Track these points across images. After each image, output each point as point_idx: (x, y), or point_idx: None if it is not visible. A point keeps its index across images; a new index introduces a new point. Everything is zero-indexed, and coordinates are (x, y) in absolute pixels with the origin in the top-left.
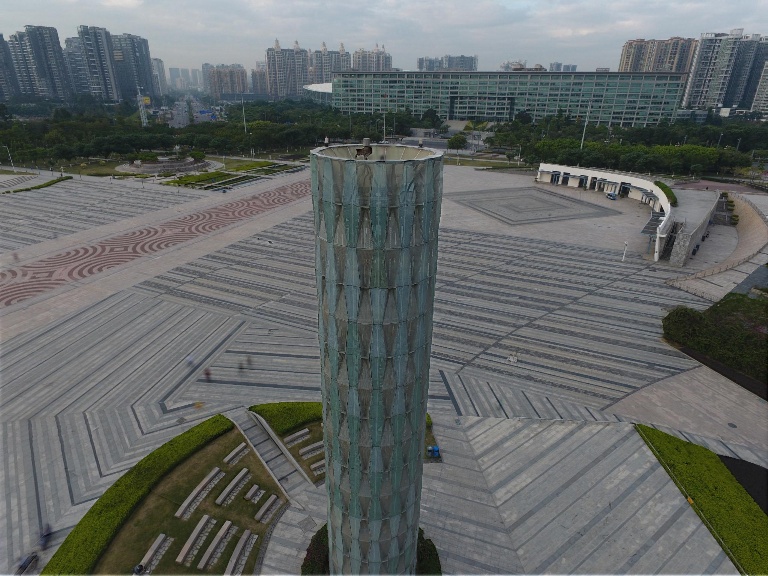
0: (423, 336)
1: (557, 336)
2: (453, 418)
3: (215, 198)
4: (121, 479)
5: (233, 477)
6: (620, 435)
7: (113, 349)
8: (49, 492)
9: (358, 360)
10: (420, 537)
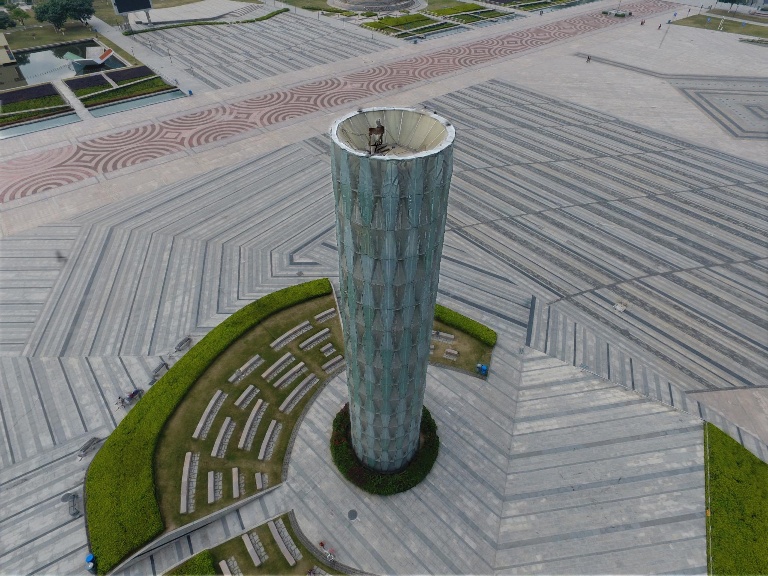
0: (413, 299)
1: (693, 297)
2: (519, 346)
3: (404, 50)
4: (247, 306)
5: (317, 332)
6: (680, 425)
7: (272, 198)
8: (206, 299)
9: (354, 302)
10: (432, 431)
